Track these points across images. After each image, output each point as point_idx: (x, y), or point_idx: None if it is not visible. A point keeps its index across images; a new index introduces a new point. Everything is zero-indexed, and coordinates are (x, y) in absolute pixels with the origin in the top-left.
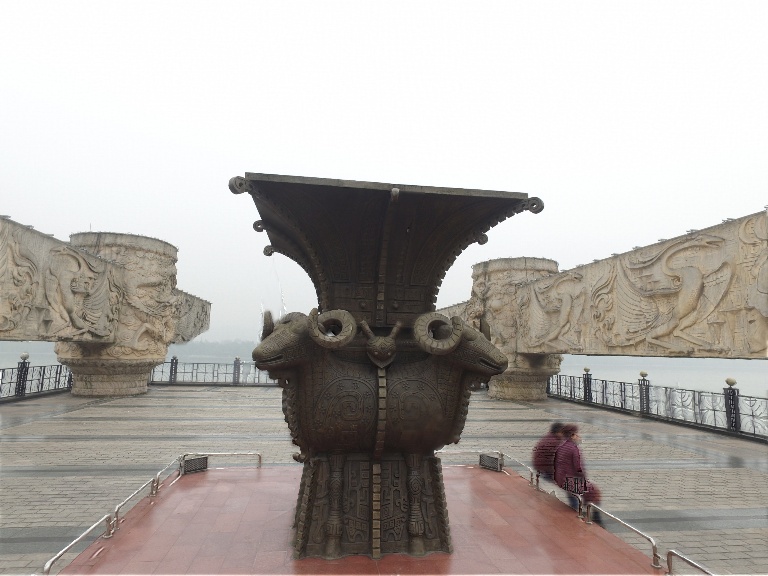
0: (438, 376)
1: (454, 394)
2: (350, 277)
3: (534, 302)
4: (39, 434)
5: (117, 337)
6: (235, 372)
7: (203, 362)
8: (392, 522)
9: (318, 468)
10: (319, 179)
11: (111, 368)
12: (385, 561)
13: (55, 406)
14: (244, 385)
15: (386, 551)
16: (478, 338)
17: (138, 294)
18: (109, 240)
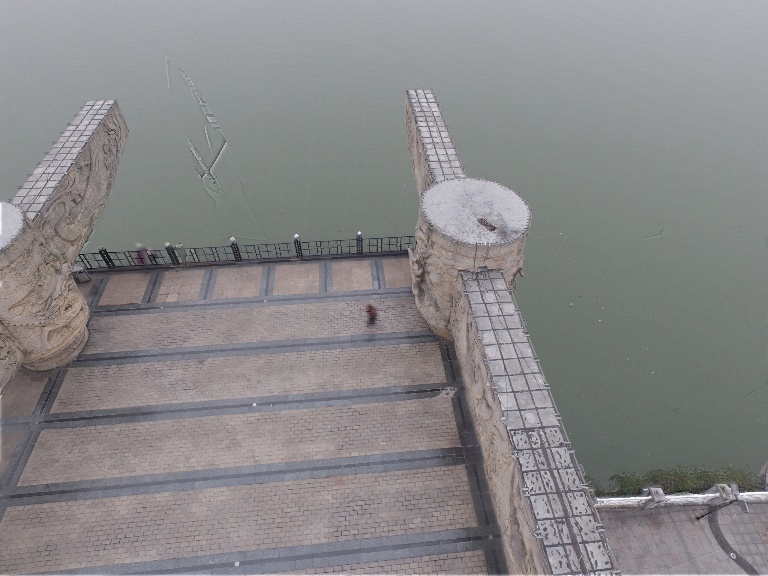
0: None
1: None
2: None
3: (464, 325)
4: (16, 571)
5: (25, 348)
6: (171, 256)
7: (133, 250)
8: None
9: None
10: None
11: None
12: None
13: (14, 427)
14: (185, 267)
15: None
16: None
17: (15, 314)
18: None
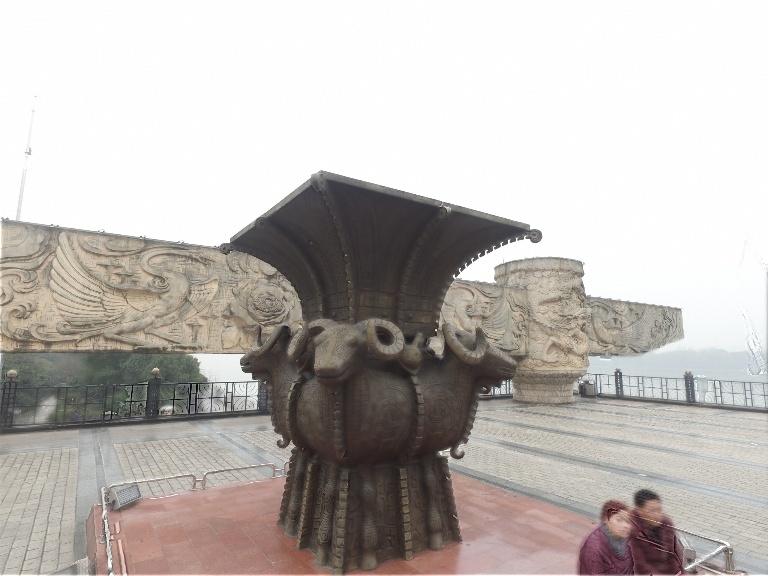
0: (320, 383)
1: (328, 403)
2: (312, 293)
3: None
4: None
5: (529, 350)
6: (688, 388)
7: (648, 375)
8: (318, 523)
9: (297, 457)
10: (245, 228)
11: (531, 378)
12: (296, 552)
13: (483, 406)
14: (701, 405)
15: (312, 548)
16: (323, 343)
17: (541, 311)
18: (512, 267)
